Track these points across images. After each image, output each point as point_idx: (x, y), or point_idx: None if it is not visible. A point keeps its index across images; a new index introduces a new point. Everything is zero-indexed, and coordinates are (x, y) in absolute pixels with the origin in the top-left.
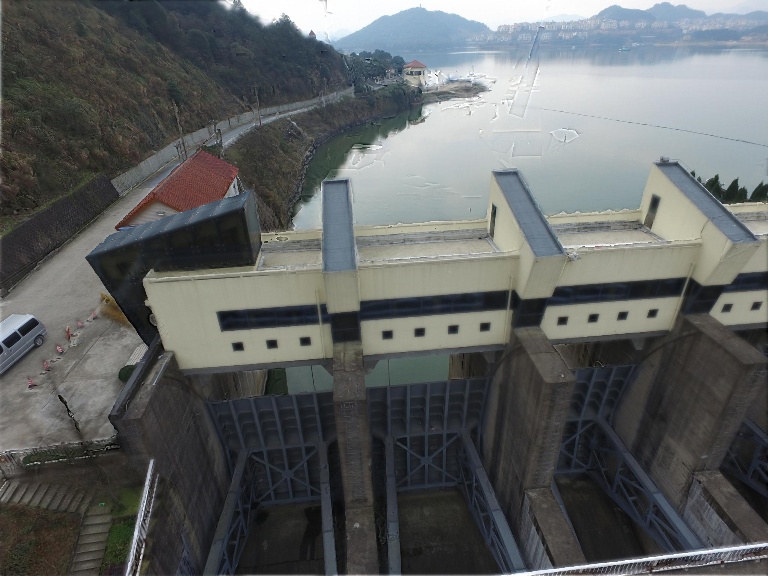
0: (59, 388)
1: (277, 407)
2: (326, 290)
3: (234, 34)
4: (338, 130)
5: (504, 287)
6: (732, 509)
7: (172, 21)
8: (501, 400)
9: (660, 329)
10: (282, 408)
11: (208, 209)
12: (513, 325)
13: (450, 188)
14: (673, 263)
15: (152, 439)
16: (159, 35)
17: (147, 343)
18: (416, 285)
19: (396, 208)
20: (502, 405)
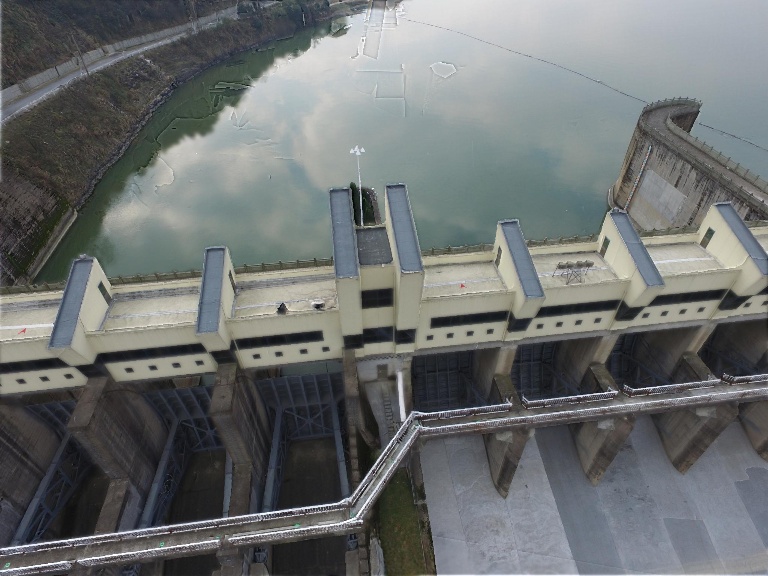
0: None
1: None
2: None
3: None
4: (212, 61)
5: None
6: (107, 508)
7: None
8: None
9: None
10: None
11: None
12: None
13: (275, 146)
14: None
15: None
16: None
17: None
18: None
19: (206, 173)
20: None
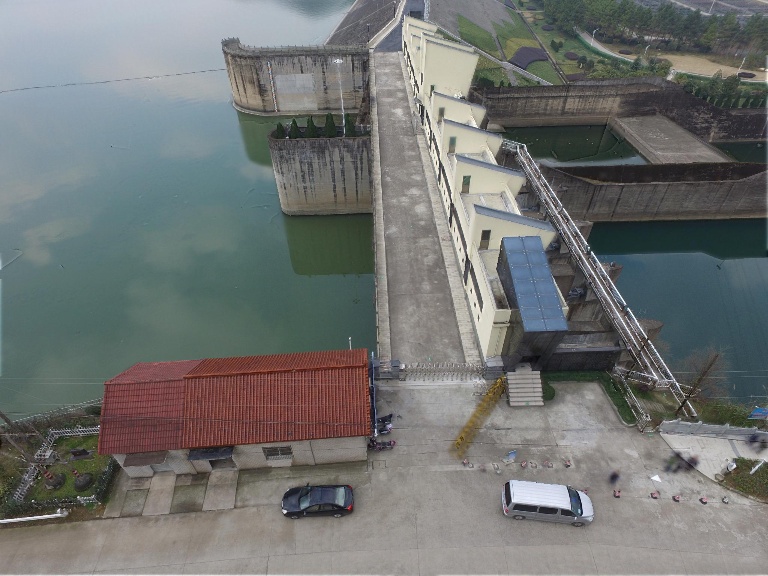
0: (564, 443)
1: None
2: None
3: None
4: None
5: None
6: None
7: None
8: None
9: None
10: None
11: (524, 259)
12: None
13: None
14: None
15: None
16: None
17: (543, 365)
18: None
19: None
20: None
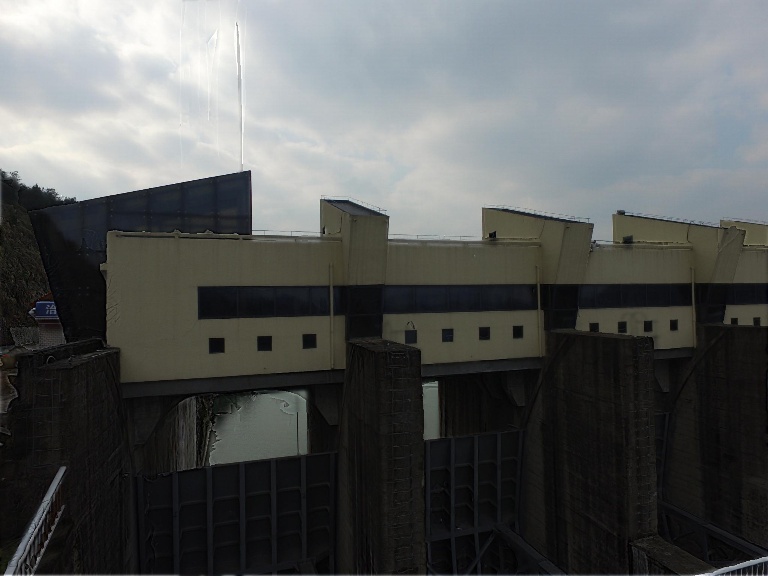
0: None
1: (245, 485)
2: (351, 244)
3: None
4: None
5: (531, 280)
6: None
7: None
8: (548, 445)
9: (685, 346)
10: (250, 493)
11: None
12: (548, 327)
13: None
14: (675, 266)
15: (75, 424)
16: None
17: None
18: (441, 269)
19: None
20: (552, 450)
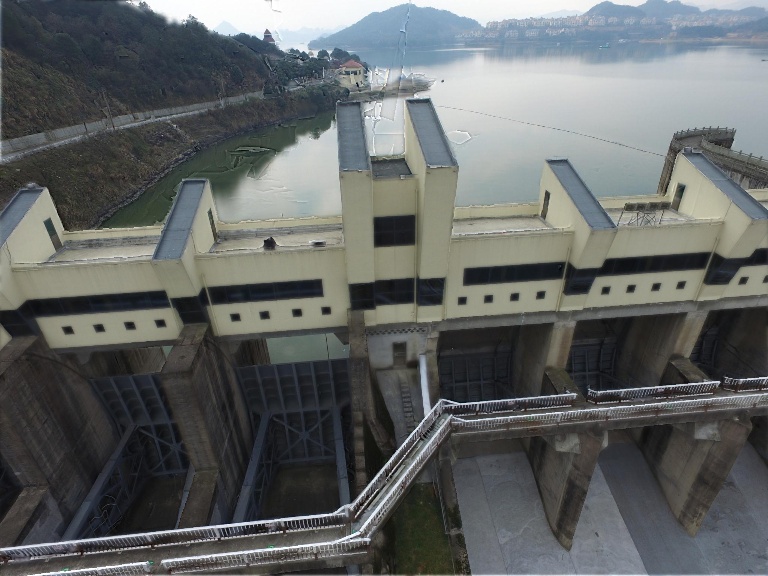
0: None
1: None
2: None
3: (127, 36)
4: (237, 132)
5: None
6: (6, 524)
7: (34, 25)
8: None
9: None
10: None
11: None
12: None
13: (289, 192)
14: None
15: None
16: (7, 40)
17: None
18: None
19: None
20: None
